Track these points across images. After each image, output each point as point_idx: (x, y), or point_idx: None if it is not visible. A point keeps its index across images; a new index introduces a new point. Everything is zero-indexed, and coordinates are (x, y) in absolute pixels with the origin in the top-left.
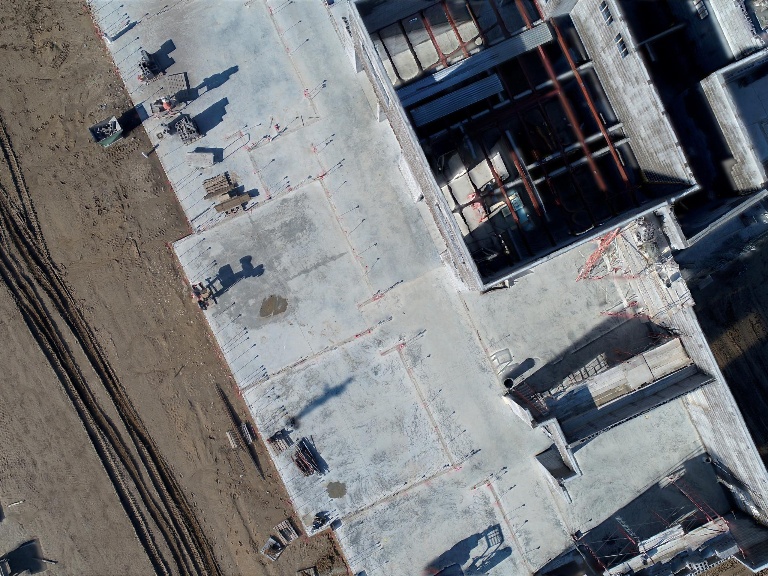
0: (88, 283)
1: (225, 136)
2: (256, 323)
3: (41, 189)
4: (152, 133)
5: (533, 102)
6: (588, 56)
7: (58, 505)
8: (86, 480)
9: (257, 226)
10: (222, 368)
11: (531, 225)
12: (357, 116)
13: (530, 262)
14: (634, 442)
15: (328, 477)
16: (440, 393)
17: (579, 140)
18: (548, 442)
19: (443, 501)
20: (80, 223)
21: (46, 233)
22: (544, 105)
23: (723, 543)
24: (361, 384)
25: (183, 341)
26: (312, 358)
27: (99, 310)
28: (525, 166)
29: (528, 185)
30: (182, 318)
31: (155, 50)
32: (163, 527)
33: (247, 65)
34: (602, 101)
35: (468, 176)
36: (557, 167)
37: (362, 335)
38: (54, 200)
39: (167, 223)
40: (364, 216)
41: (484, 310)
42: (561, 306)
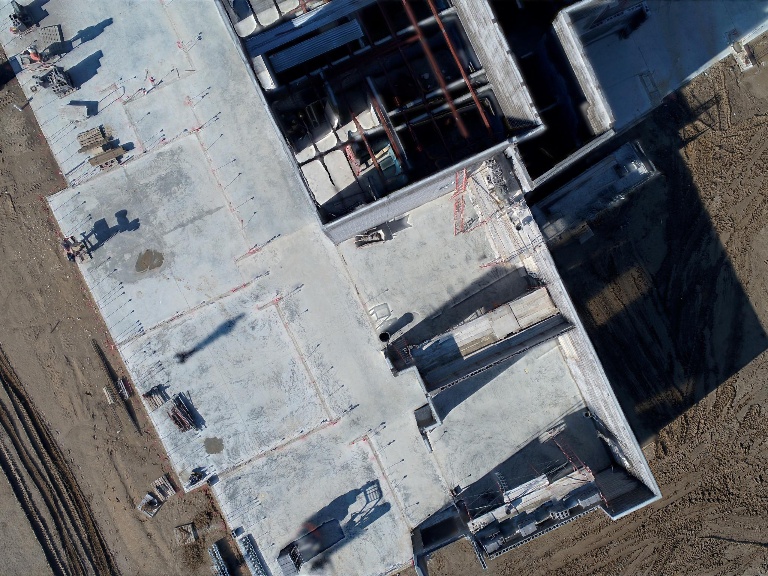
0: None
1: (100, 89)
2: (132, 278)
3: None
4: (26, 86)
5: (393, 48)
6: (451, 2)
7: None
8: None
9: (132, 180)
10: (98, 323)
11: (404, 176)
12: (233, 69)
13: None
14: (514, 397)
15: (205, 433)
16: (318, 348)
17: (441, 86)
18: None
19: (321, 456)
20: None
21: None
22: (405, 51)
23: (586, 492)
24: (238, 339)
25: (59, 296)
26: (189, 313)
27: None
28: (386, 113)
29: (389, 132)
30: (58, 273)
31: (28, 2)
32: (40, 484)
33: (122, 17)
34: (469, 49)
35: (346, 129)
36: (419, 114)
37: (239, 290)
38: None
39: (42, 177)
40: (241, 170)
41: (362, 264)
42: (440, 260)
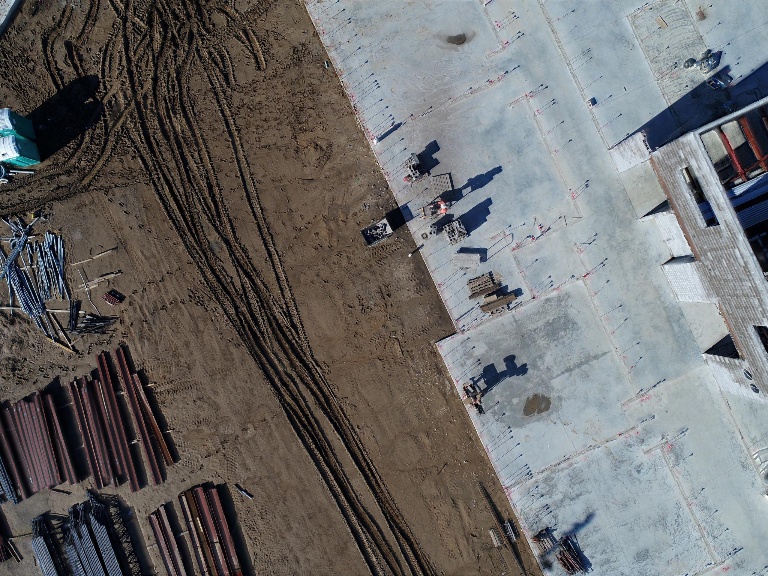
0: (351, 381)
1: (489, 236)
2: (520, 422)
3: (304, 288)
4: (417, 233)
5: None
6: None
7: None
8: None
9: (521, 325)
10: (485, 466)
11: None
12: (619, 216)
13: None
14: None
15: (592, 575)
16: (703, 492)
17: None
18: None
19: None
20: (343, 322)
21: (309, 331)
22: None
23: None
24: (624, 483)
25: (446, 439)
26: (575, 457)
27: (361, 408)
28: None
29: None
30: (445, 416)
31: (420, 151)
32: None
33: (511, 165)
34: None
35: None
36: None
37: (625, 434)
38: (317, 299)
39: (430, 322)
40: (627, 315)
41: (746, 409)
42: None
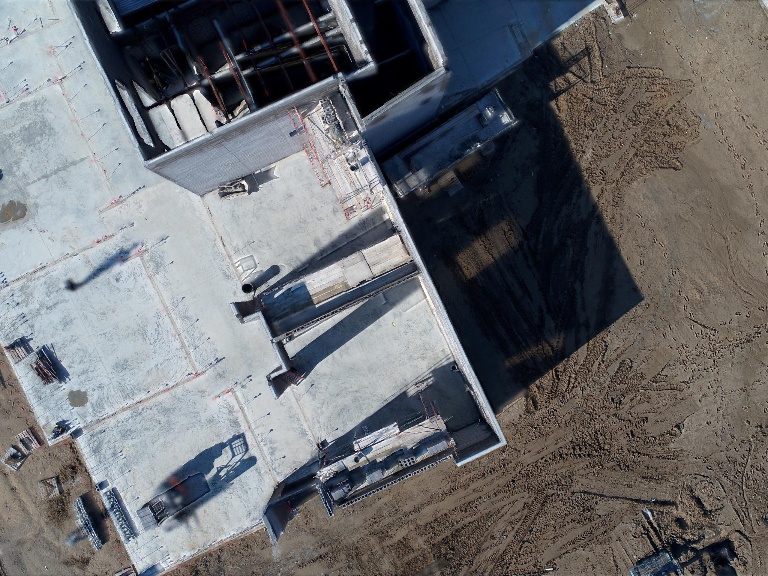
0: None
1: None
2: None
3: None
4: None
5: None
6: None
7: None
8: None
9: None
10: None
11: None
12: None
13: None
14: (381, 350)
15: (69, 385)
16: (183, 300)
17: (289, 30)
18: (294, 350)
19: (187, 410)
20: None
21: None
22: None
23: (436, 440)
24: (102, 291)
25: None
26: (52, 265)
27: None
28: (233, 56)
29: (236, 75)
30: None
31: None
32: None
33: None
34: None
35: None
36: (267, 57)
37: (103, 241)
38: None
39: None
40: (105, 120)
41: (228, 216)
42: (307, 212)
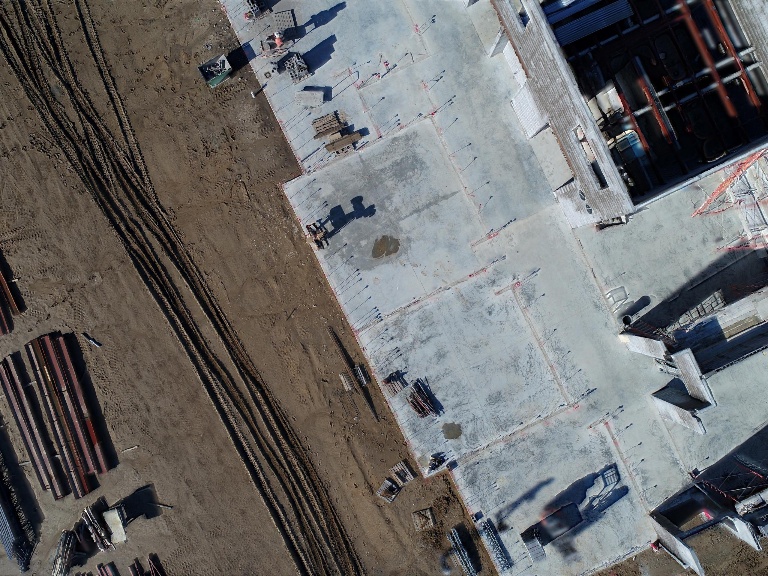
0: (197, 227)
1: (334, 74)
2: (368, 264)
3: (147, 132)
4: (260, 72)
5: (664, 26)
6: None
7: (172, 450)
8: (199, 425)
9: (368, 166)
10: (334, 310)
11: None
12: (468, 51)
13: (680, 182)
14: (751, 379)
15: (443, 418)
16: (555, 332)
17: (710, 65)
18: (664, 380)
19: (559, 441)
20: (188, 166)
21: (154, 177)
22: (675, 29)
23: None
24: (475, 324)
25: (294, 284)
26: (425, 299)
27: (209, 254)
28: (655, 93)
29: (659, 112)
30: (293, 261)
31: None
32: (277, 471)
33: (355, 1)
34: (730, 26)
35: None
36: (688, 93)
37: (475, 275)
38: (161, 143)
39: (276, 164)
40: (476, 154)
41: (599, 248)
42: (677, 242)
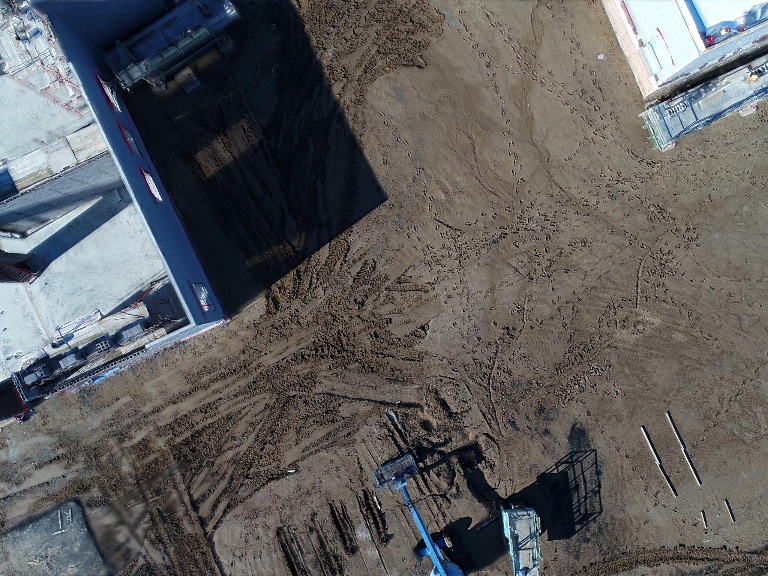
0: None
1: None
2: None
3: None
4: None
5: None
6: None
7: None
8: None
9: None
10: None
11: None
12: None
13: None
14: (116, 248)
15: None
16: None
17: None
18: (27, 248)
19: None
20: None
21: None
22: None
23: None
24: None
25: None
26: None
27: None
28: None
29: None
30: None
31: None
32: None
33: None
34: None
35: None
36: None
37: None
38: None
39: None
40: None
41: None
42: (39, 108)
